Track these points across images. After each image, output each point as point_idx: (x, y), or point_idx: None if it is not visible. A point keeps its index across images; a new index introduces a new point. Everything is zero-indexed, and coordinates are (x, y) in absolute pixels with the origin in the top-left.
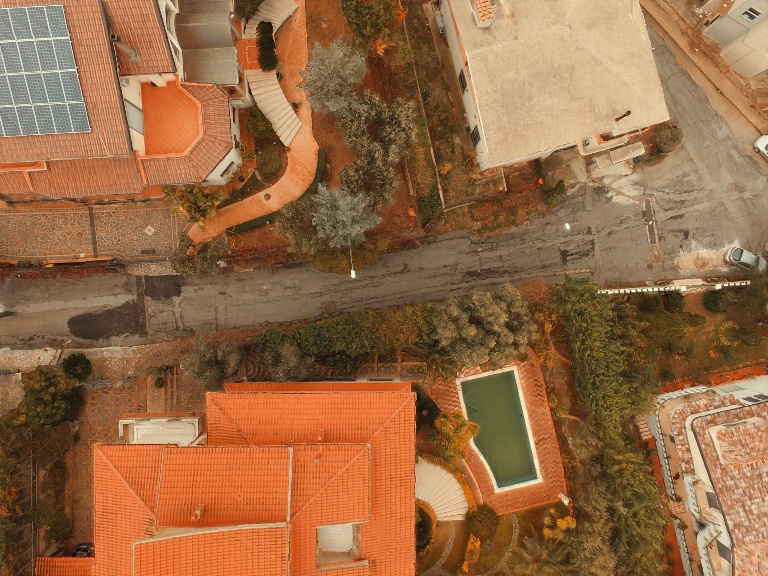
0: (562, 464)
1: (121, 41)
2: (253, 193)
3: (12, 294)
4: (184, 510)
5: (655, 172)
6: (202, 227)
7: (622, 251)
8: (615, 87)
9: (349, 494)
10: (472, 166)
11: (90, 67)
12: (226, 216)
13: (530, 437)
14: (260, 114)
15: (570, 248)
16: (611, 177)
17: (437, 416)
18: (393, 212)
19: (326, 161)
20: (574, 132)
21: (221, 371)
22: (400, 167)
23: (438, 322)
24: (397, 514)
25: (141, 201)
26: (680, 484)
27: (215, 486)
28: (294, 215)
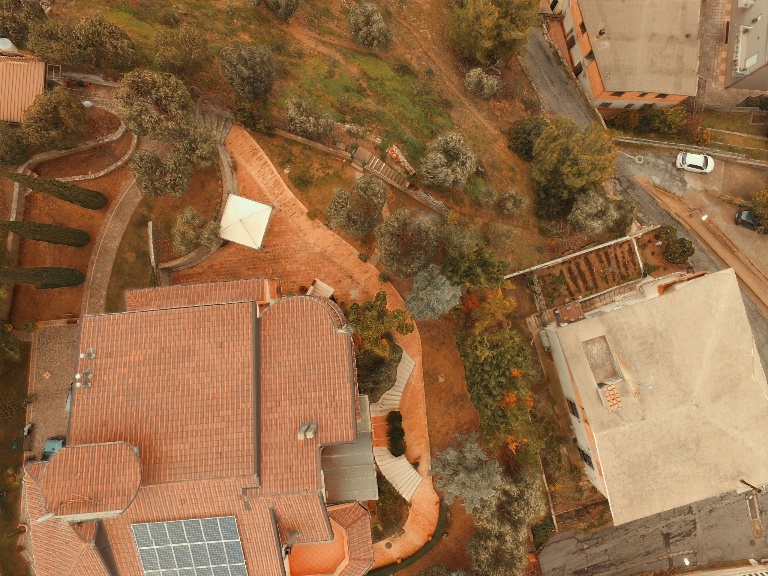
0: None
1: None
2: (374, 542)
3: None
4: None
5: None
6: None
7: (724, 528)
8: (740, 453)
9: None
10: (580, 477)
11: (257, 558)
12: None
13: None
14: (387, 489)
15: (672, 530)
16: None
17: None
18: None
19: (447, 512)
20: (699, 493)
21: None
22: None
23: None
24: None
25: None
26: None
27: None
28: None
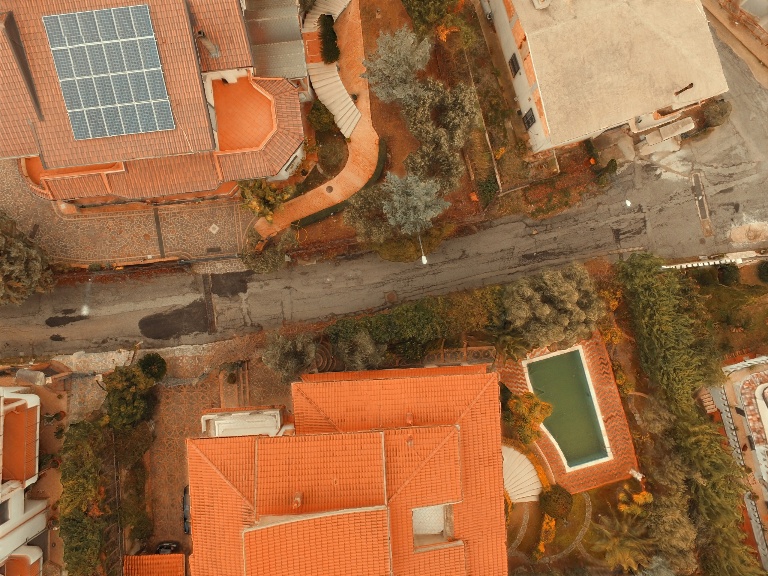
0: (632, 441)
1: (206, 37)
2: (315, 186)
3: (84, 298)
4: (282, 498)
5: (702, 147)
6: (270, 222)
7: (674, 227)
8: (674, 61)
9: (442, 475)
10: (525, 149)
11: (174, 65)
12: (289, 210)
13: (598, 415)
14: (323, 107)
15: (622, 227)
16: (659, 154)
17: (509, 398)
18: (454, 198)
19: (387, 150)
20: (634, 108)
21: (300, 362)
22: (460, 153)
23: (511, 303)
24: (487, 494)
25: (210, 199)
26: (748, 455)
27: (311, 473)
28: (362, 205)
